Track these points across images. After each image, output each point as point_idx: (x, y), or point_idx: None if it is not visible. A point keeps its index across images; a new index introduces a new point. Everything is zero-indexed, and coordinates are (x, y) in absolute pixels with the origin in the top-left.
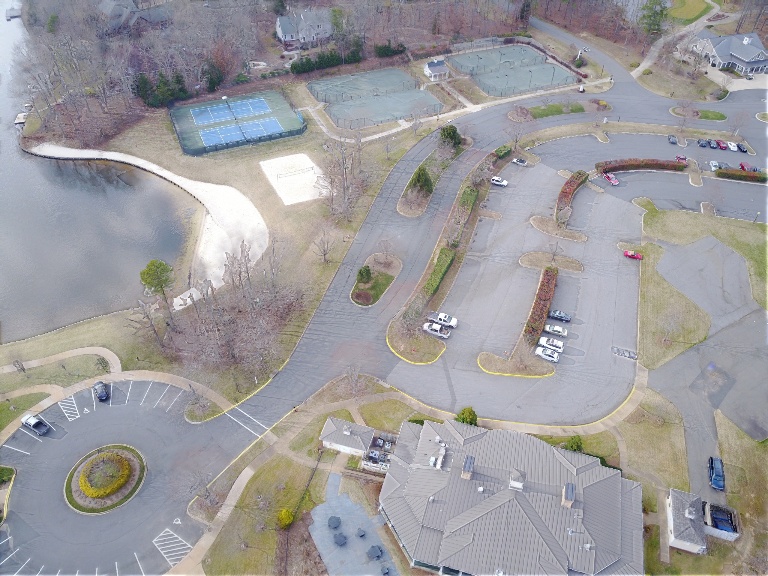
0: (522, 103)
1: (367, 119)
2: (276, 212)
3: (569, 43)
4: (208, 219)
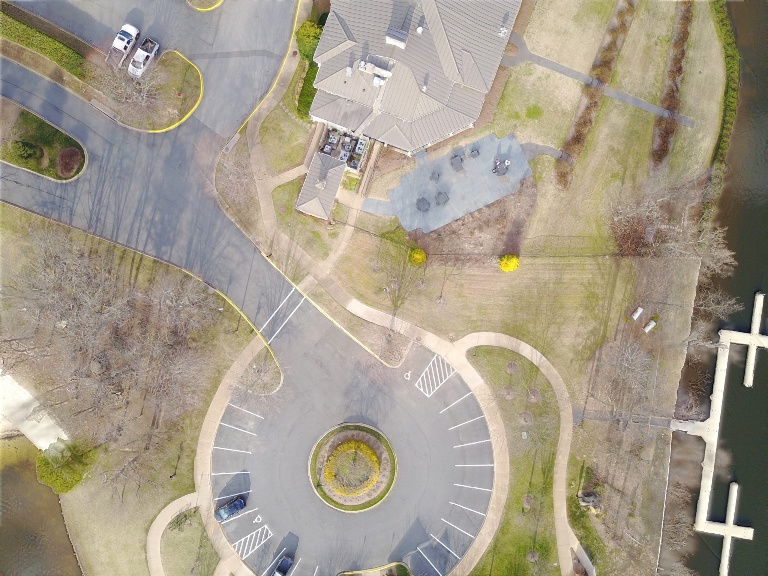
0: None
1: None
2: None
3: None
4: None
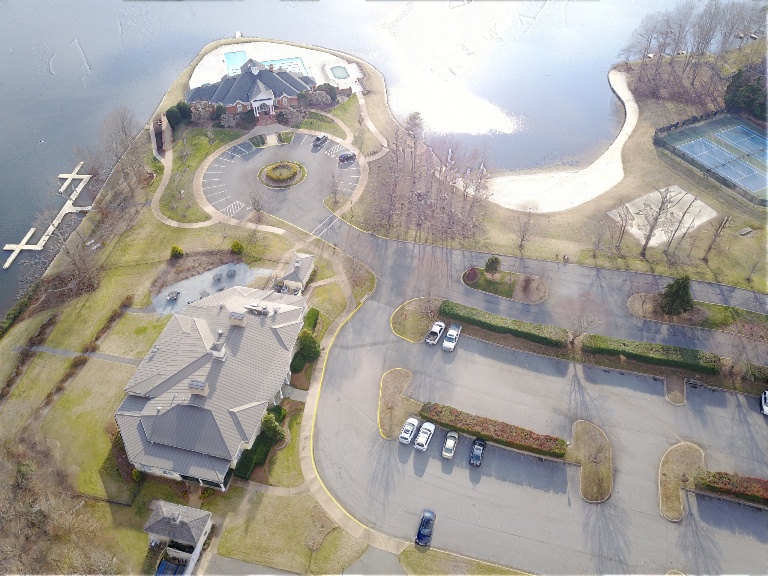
0: None
1: None
2: (593, 209)
3: None
4: (566, 174)
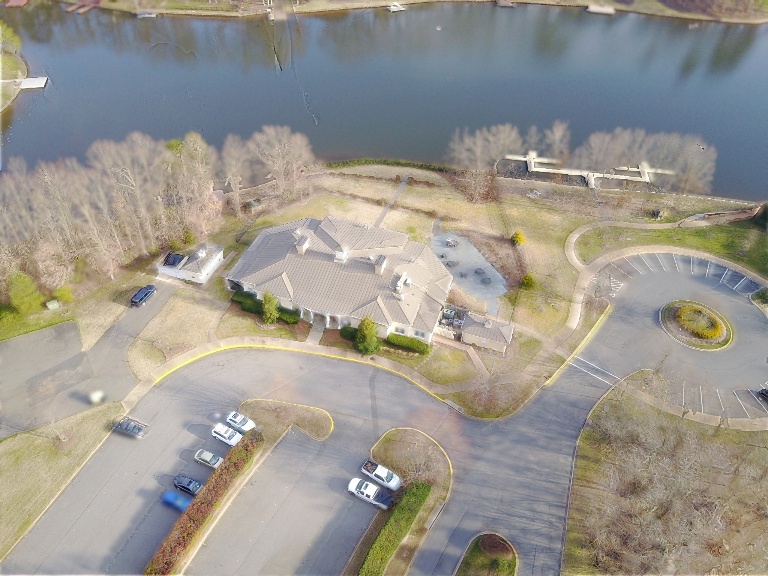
0: None
1: None
2: None
3: None
4: None
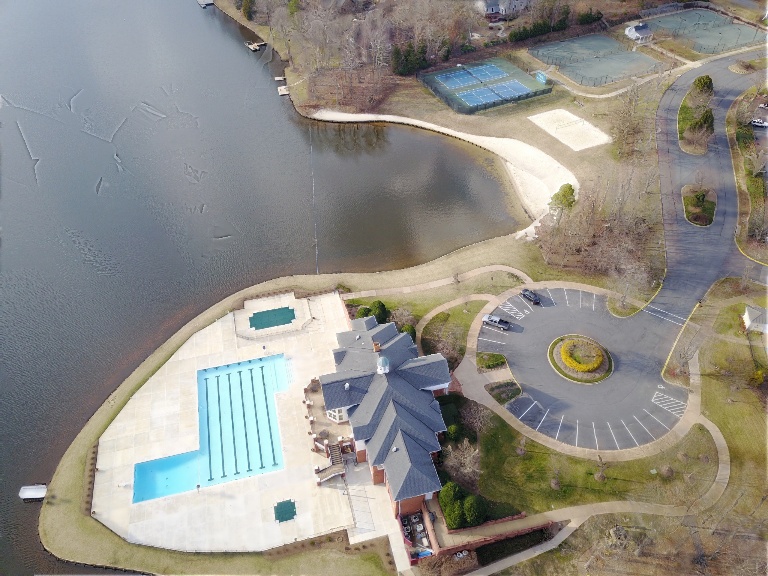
0: (735, 58)
1: (608, 77)
2: (570, 157)
3: (747, 5)
4: (510, 166)
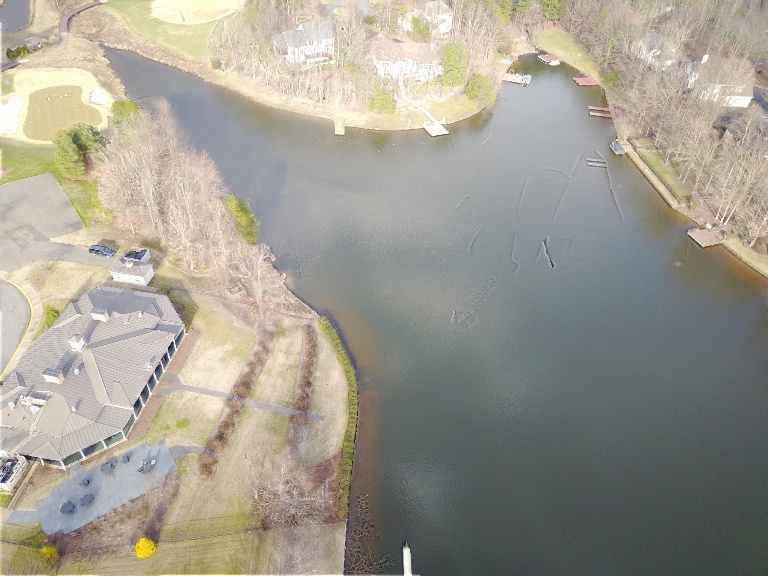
0: None
1: None
2: None
3: None
4: None
